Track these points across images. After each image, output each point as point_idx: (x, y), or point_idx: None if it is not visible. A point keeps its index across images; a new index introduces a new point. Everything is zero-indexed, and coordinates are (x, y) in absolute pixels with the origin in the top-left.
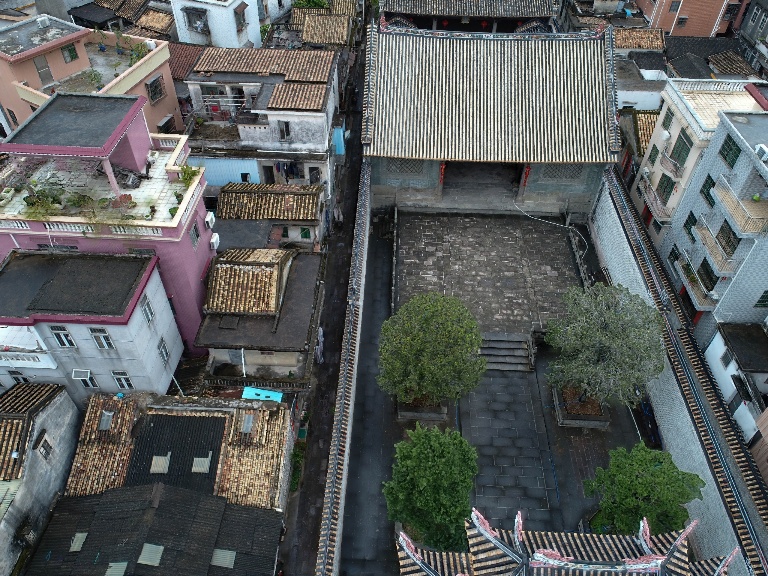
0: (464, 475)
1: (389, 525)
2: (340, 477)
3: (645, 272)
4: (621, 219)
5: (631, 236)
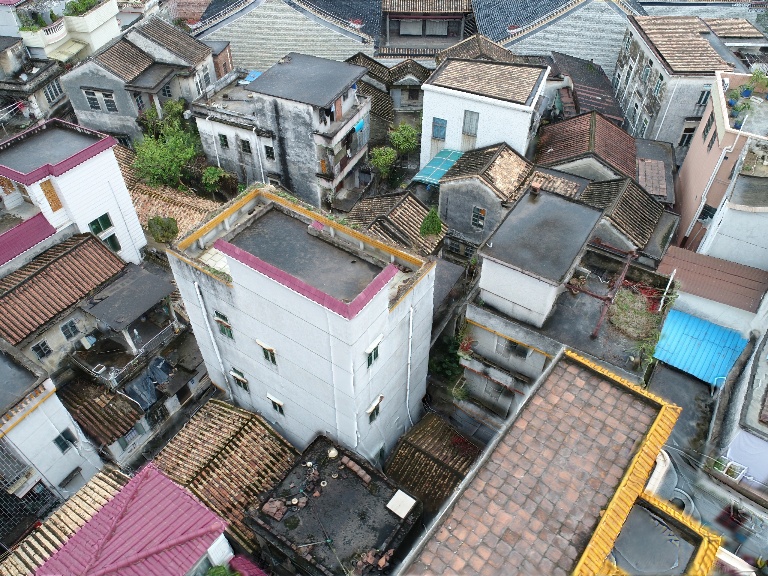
0: None
1: None
2: None
3: (723, 1)
4: (671, 3)
5: (691, 0)
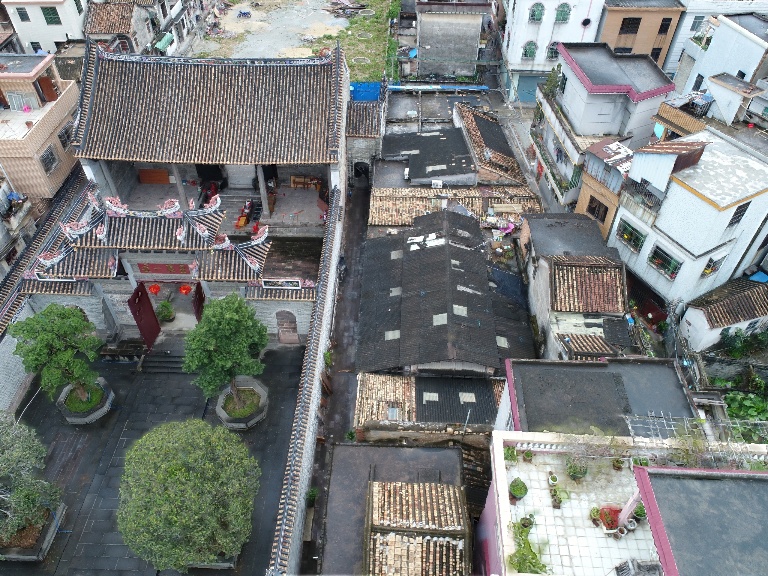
0: (200, 325)
1: (272, 411)
2: (304, 368)
3: None
4: None
5: None
